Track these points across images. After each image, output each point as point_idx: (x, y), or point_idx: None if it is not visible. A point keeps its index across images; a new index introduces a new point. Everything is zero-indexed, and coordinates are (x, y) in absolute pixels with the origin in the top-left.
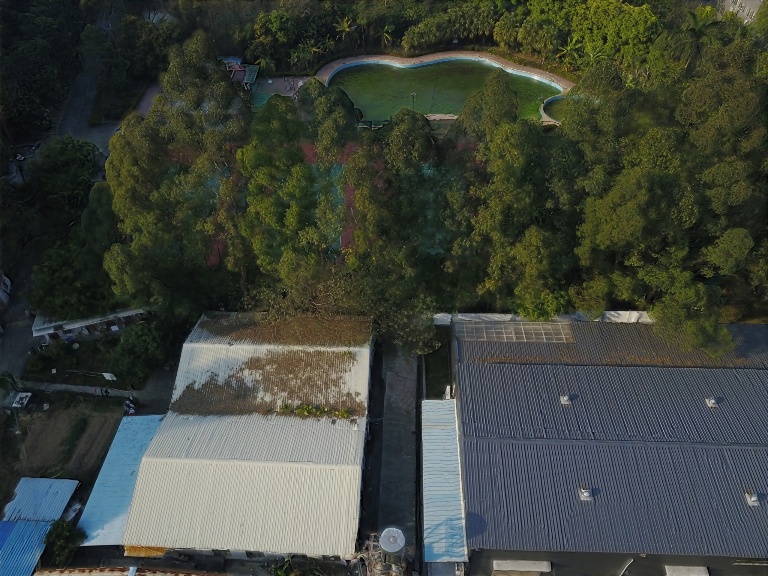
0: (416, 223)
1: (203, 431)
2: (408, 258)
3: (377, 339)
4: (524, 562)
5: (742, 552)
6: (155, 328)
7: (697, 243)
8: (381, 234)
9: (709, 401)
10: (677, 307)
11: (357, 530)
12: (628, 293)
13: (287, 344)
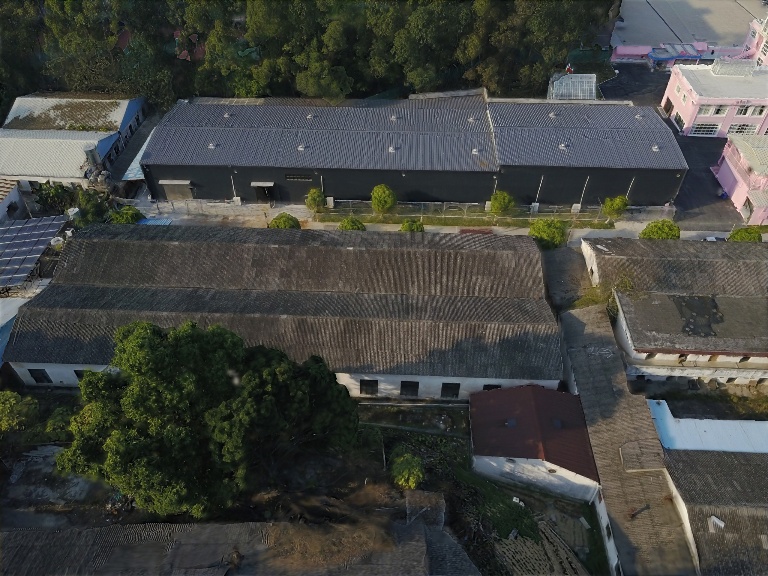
0: (151, 19)
1: (17, 132)
2: (152, 45)
3: (146, 107)
4: (176, 181)
5: (282, 165)
6: (5, 96)
7: (319, 33)
8: (134, 29)
9: (308, 116)
10: (310, 74)
11: (88, 167)
12: (283, 67)
13: (80, 99)
